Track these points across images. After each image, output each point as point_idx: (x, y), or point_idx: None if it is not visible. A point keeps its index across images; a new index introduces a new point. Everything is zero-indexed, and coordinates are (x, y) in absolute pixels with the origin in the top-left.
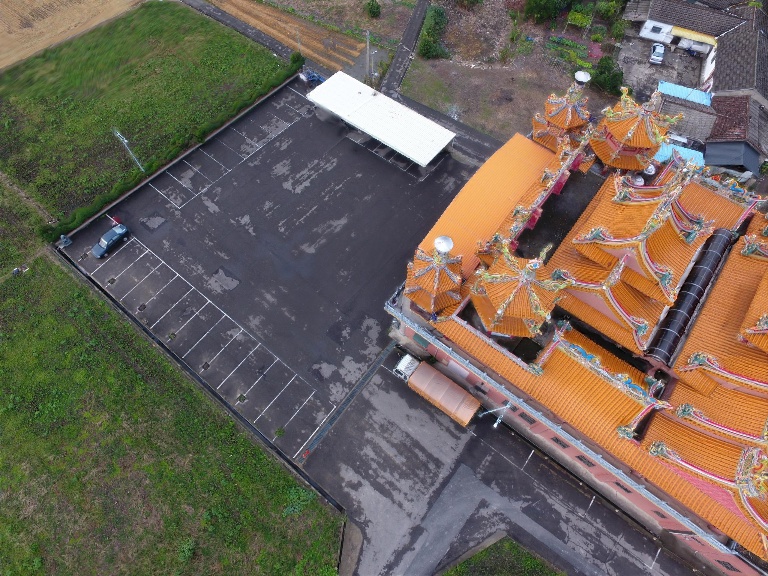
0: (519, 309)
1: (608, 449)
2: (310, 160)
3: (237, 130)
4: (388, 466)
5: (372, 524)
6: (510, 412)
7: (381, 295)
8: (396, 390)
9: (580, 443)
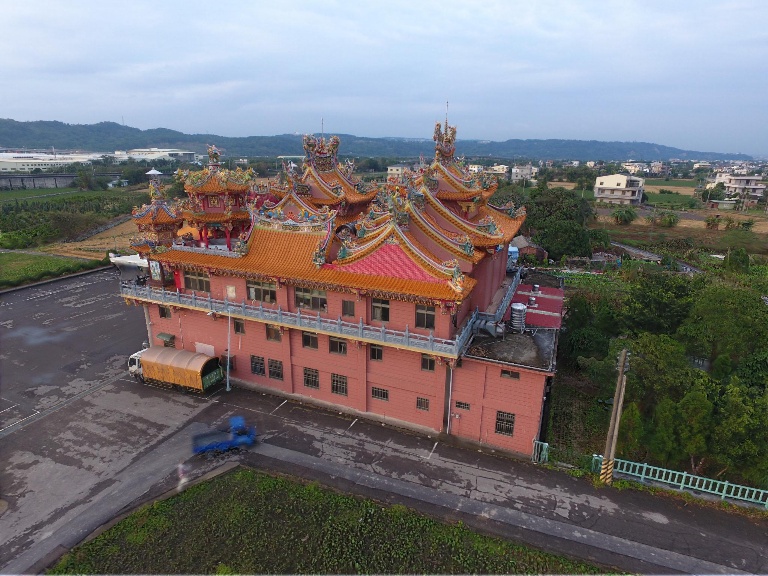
0: (211, 188)
1: (308, 277)
2: (101, 294)
3: (34, 289)
4: (88, 441)
5: (32, 493)
6: (263, 382)
7: (140, 343)
8: (129, 390)
9: (301, 315)
